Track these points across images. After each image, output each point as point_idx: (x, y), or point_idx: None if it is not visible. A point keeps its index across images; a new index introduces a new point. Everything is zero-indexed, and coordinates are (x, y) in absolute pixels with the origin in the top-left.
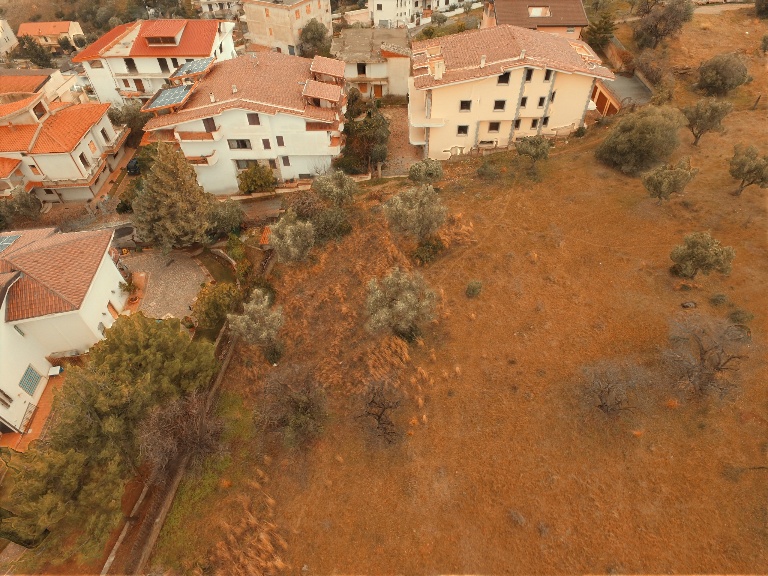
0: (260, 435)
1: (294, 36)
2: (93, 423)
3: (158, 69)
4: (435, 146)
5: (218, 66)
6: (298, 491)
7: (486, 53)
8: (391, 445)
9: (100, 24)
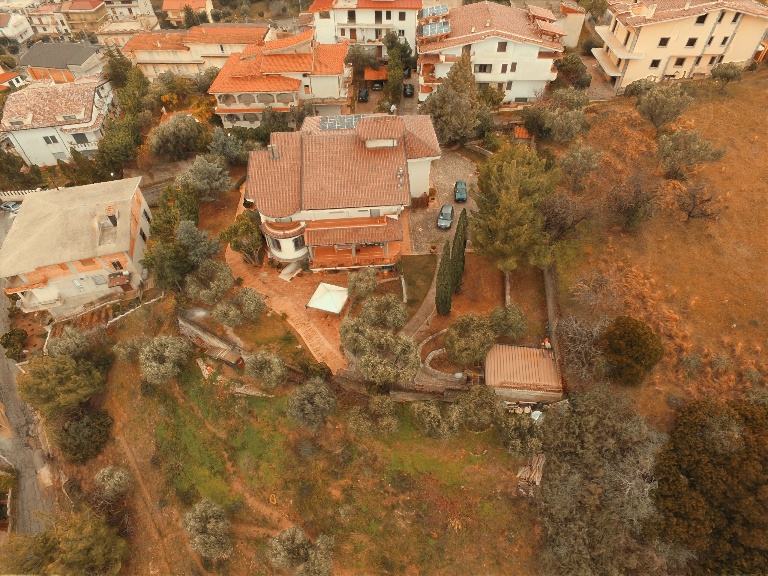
0: (620, 215)
1: (459, 2)
2: (517, 200)
3: (373, 20)
4: (628, 77)
5: (449, 12)
6: (640, 254)
7: (684, 0)
8: (695, 233)
9: (227, 1)
